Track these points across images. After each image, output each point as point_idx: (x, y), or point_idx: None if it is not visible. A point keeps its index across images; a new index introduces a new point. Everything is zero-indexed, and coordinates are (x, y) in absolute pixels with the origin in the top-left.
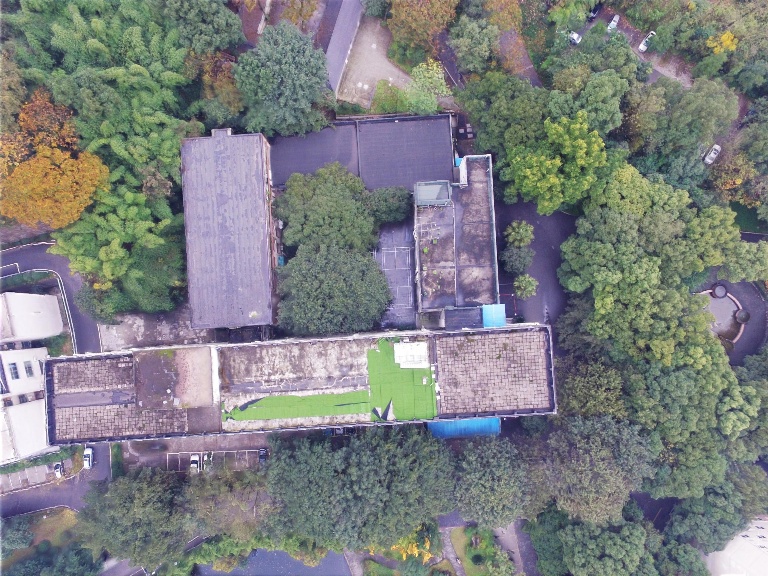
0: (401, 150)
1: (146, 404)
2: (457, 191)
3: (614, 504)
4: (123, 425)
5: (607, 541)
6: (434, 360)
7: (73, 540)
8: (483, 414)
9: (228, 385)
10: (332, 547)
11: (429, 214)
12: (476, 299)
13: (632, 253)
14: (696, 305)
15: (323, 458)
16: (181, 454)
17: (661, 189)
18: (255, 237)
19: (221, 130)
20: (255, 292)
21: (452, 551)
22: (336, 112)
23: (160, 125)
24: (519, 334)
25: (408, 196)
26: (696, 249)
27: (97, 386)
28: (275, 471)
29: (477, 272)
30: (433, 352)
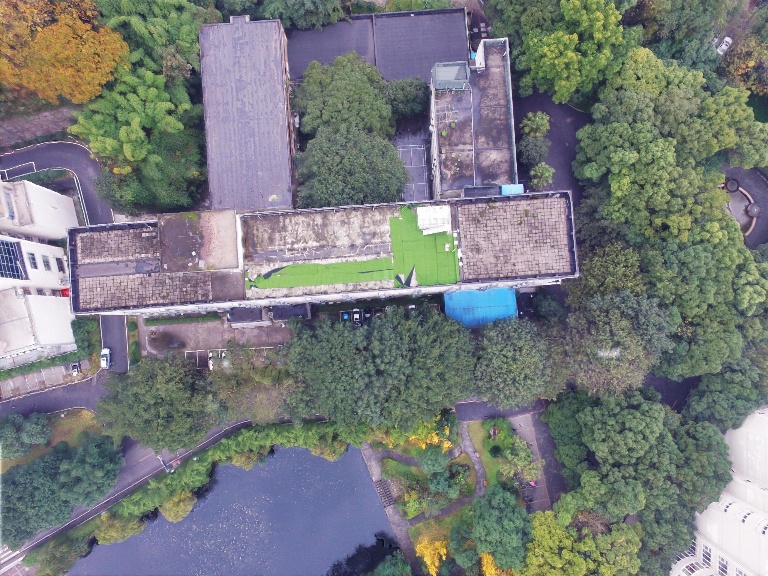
0: (417, 43)
1: (171, 267)
2: (474, 75)
3: (634, 372)
4: (147, 294)
5: (627, 416)
6: (456, 227)
7: None
8: (505, 279)
9: (251, 254)
10: (351, 440)
11: (447, 97)
12: (494, 181)
13: (648, 132)
14: (711, 183)
15: (345, 336)
16: (199, 352)
17: (676, 70)
18: (274, 122)
19: (239, 17)
20: (275, 176)
21: (470, 445)
22: (351, 11)
23: (179, 10)
24: (540, 201)
25: (425, 86)
26: (711, 127)
27: (120, 256)
28: (297, 349)
29: (495, 155)
30: (455, 219)
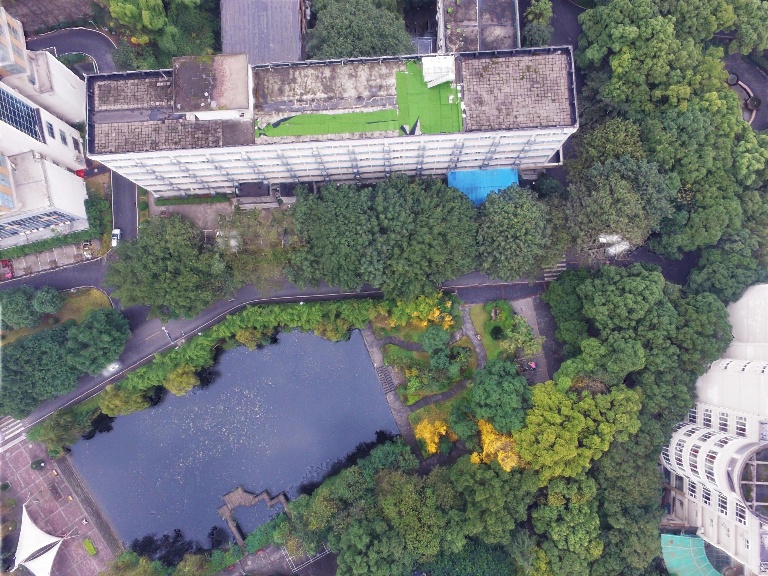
0: None
1: (184, 107)
2: None
3: (634, 228)
4: (160, 140)
5: (627, 280)
6: (460, 81)
7: None
8: None
9: (262, 104)
10: (354, 317)
11: None
12: None
13: (648, 7)
14: (710, 57)
15: (350, 197)
16: (207, 232)
17: None
18: None
19: None
20: (286, 48)
21: (472, 328)
22: None
23: None
24: (542, 57)
25: None
26: (709, 3)
27: (136, 104)
28: (303, 208)
29: (499, 30)
30: (459, 73)
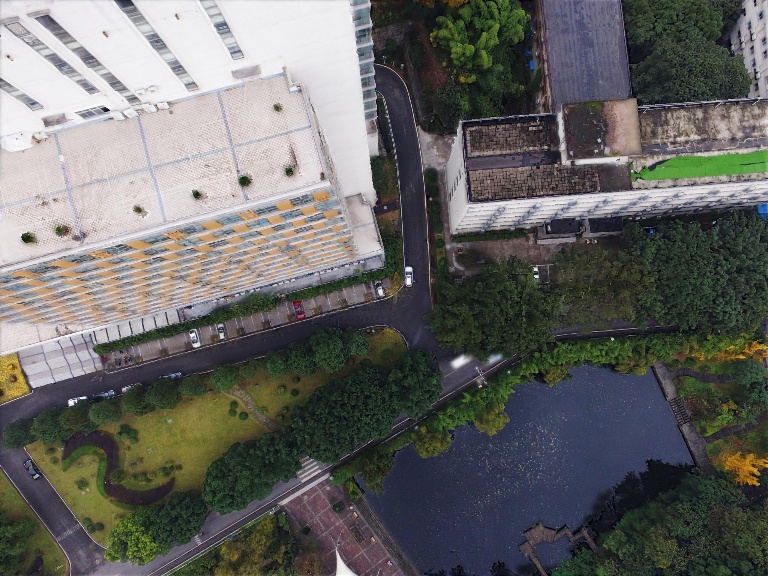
0: None
1: (577, 154)
2: None
3: None
4: (536, 186)
5: None
6: None
7: (394, 358)
8: None
9: None
10: (665, 352)
11: None
12: None
13: None
14: None
15: (699, 236)
16: None
17: None
18: (612, 33)
19: None
20: (615, 85)
21: None
22: None
23: None
24: None
25: None
26: None
27: (509, 149)
28: (654, 248)
29: None
30: None
